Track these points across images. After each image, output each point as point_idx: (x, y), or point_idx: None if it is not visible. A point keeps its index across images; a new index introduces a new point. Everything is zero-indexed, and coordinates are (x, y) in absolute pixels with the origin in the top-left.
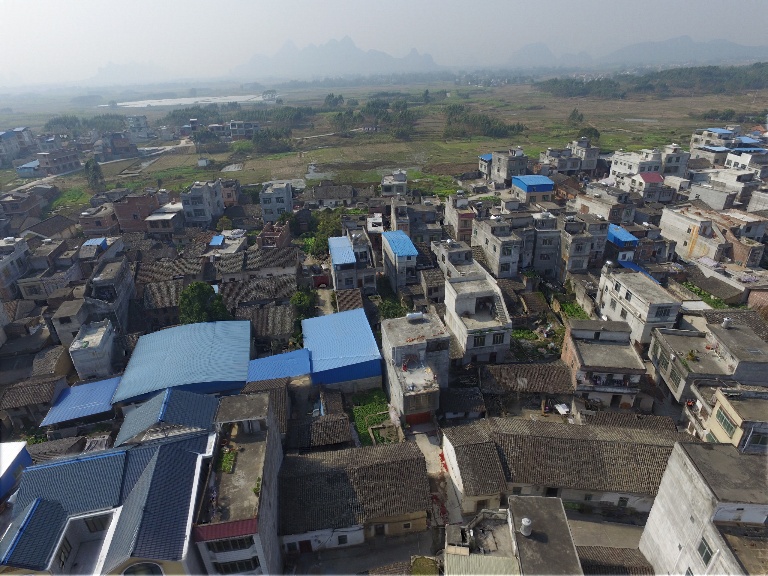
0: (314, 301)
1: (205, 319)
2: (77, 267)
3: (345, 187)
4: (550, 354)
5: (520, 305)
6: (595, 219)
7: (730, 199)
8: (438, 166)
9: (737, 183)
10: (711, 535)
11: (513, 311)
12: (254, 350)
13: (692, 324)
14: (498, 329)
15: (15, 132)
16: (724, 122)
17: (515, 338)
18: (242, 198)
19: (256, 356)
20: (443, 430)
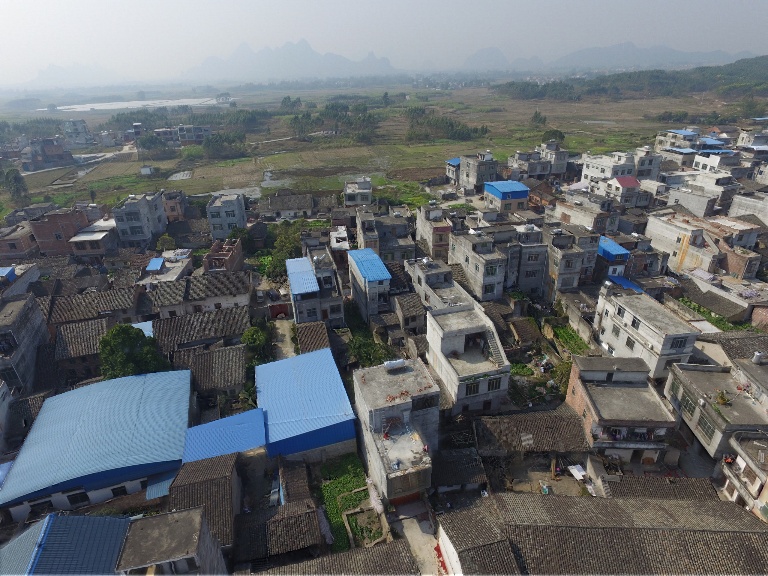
0: (271, 336)
1: (132, 372)
2: None
3: (304, 197)
4: (551, 394)
5: (510, 333)
6: (584, 231)
7: (711, 204)
8: (403, 171)
9: (716, 187)
10: None
11: (503, 341)
12: (196, 408)
13: (703, 351)
14: (494, 373)
15: None
16: (677, 124)
17: None
18: (188, 211)
19: (199, 415)
20: (439, 520)
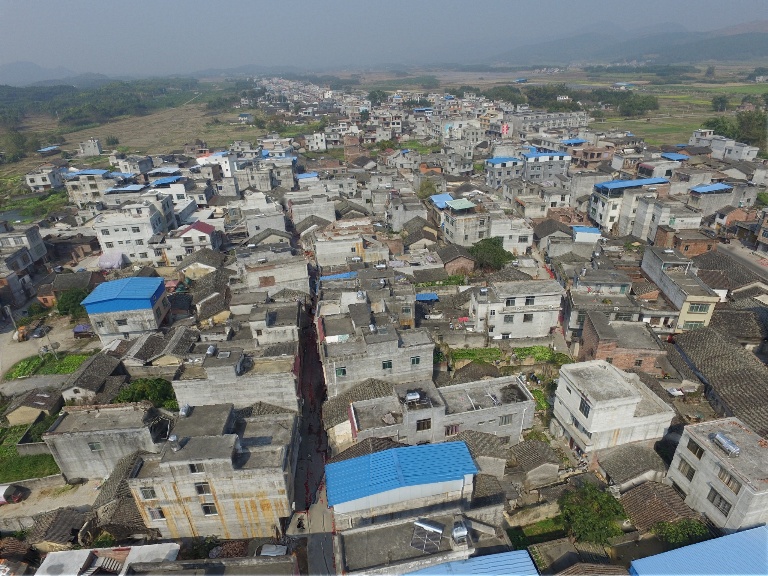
0: None
1: None
2: None
3: None
4: None
5: None
6: (380, 271)
7: None
8: None
9: (269, 205)
10: None
11: None
12: None
13: None
14: None
15: None
16: None
17: (550, 407)
18: None
19: None
20: None
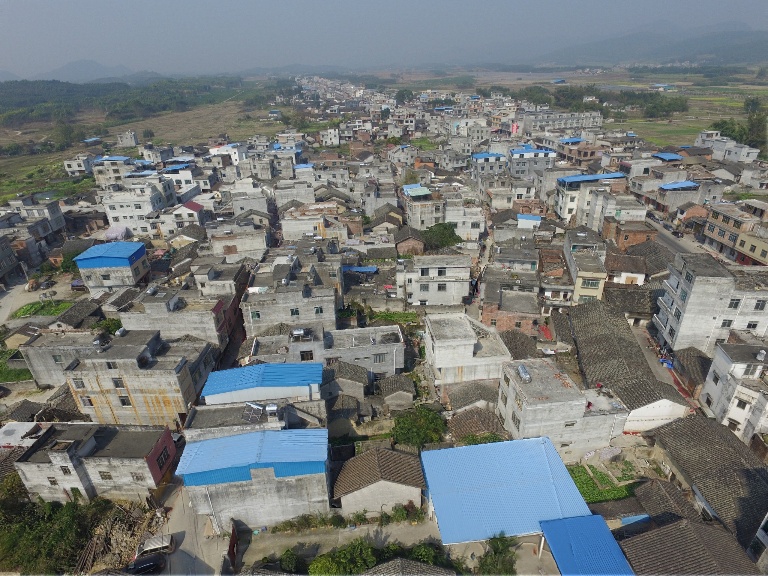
0: None
1: None
2: None
3: None
4: None
5: None
6: (316, 242)
7: (267, 202)
8: None
9: (255, 189)
10: (738, 294)
11: None
12: None
13: None
14: None
15: None
16: (18, 157)
17: None
18: None
19: None
20: None
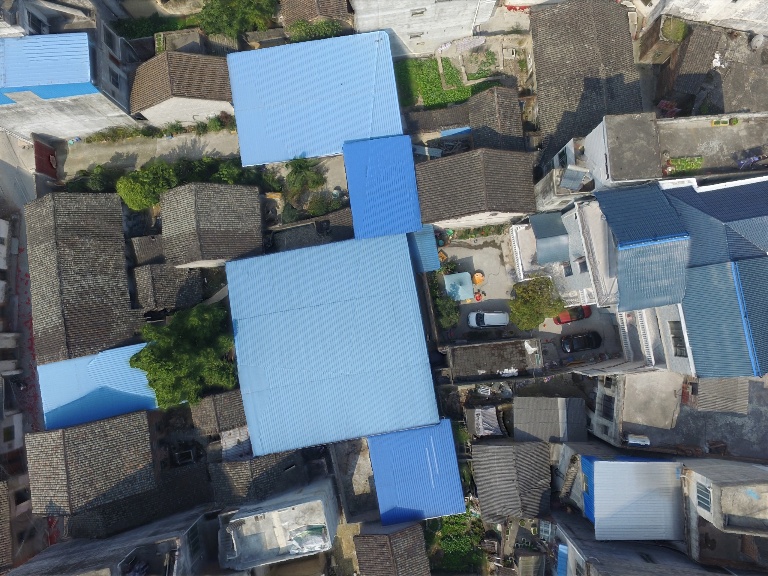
0: (119, 173)
1: (230, 339)
2: None
3: None
4: None
5: None
6: None
7: None
8: None
9: None
10: None
11: None
12: None
13: None
14: None
15: None
16: None
17: None
18: None
19: None
20: None
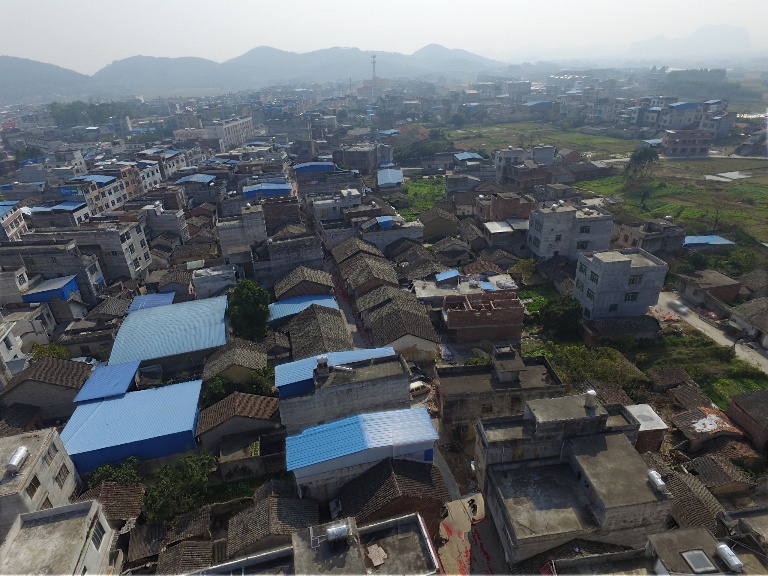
0: None
1: None
2: (354, 232)
3: None
4: None
5: None
6: None
7: None
8: None
9: None
10: None
11: None
12: (193, 366)
13: None
14: None
15: (704, 104)
16: None
17: None
18: None
19: (193, 372)
20: None
